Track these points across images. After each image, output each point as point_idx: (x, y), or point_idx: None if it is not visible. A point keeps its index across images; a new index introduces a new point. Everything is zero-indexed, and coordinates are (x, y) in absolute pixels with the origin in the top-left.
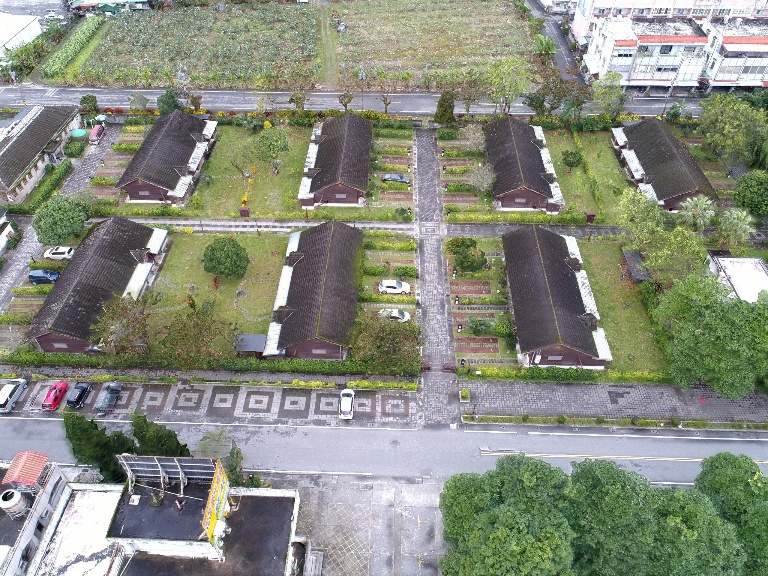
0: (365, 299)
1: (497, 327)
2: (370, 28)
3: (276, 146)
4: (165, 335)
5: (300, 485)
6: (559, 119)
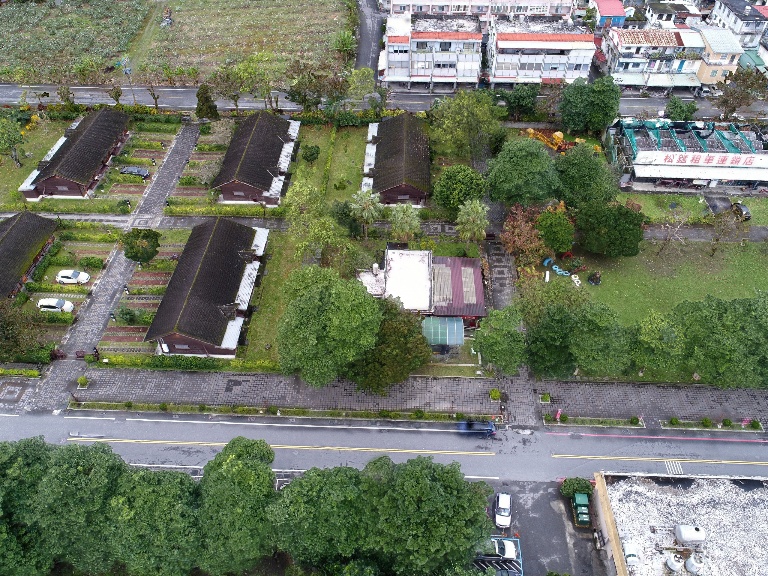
0: (35, 289)
1: (145, 316)
2: (191, 24)
3: (2, 139)
4: None
5: None
6: (324, 114)
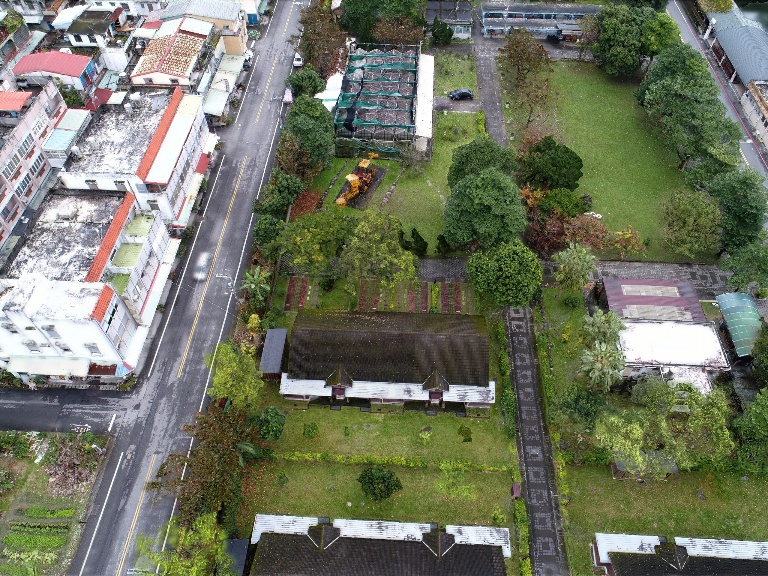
0: None
1: None
2: None
3: None
4: None
5: None
6: None
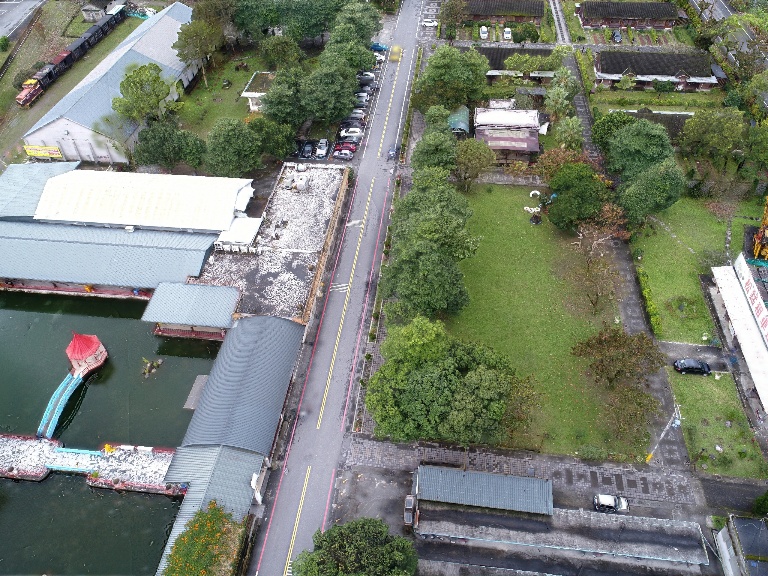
0: None
1: None
2: None
3: None
4: None
5: (393, 18)
6: None
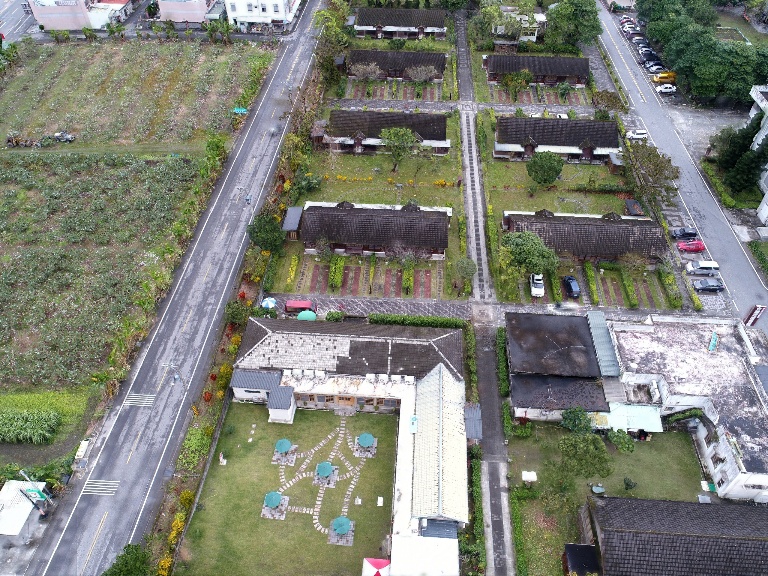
0: None
1: None
2: None
3: None
4: (612, 207)
5: (694, 150)
6: None
